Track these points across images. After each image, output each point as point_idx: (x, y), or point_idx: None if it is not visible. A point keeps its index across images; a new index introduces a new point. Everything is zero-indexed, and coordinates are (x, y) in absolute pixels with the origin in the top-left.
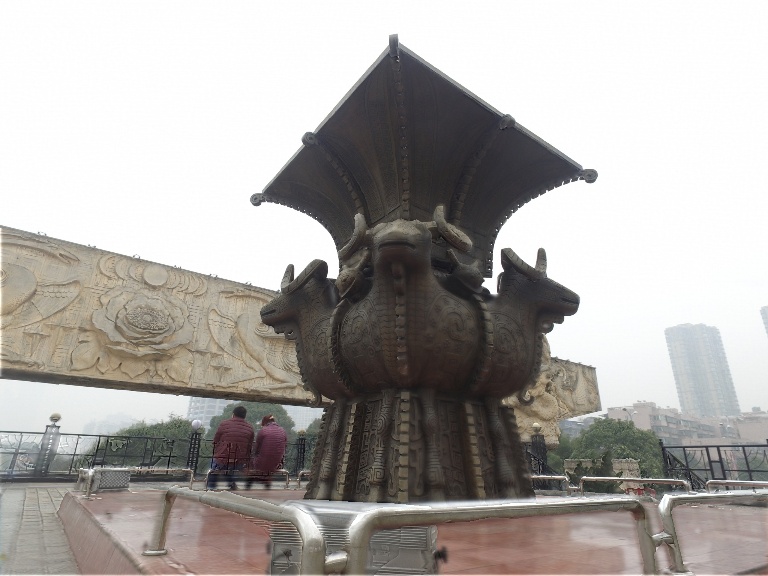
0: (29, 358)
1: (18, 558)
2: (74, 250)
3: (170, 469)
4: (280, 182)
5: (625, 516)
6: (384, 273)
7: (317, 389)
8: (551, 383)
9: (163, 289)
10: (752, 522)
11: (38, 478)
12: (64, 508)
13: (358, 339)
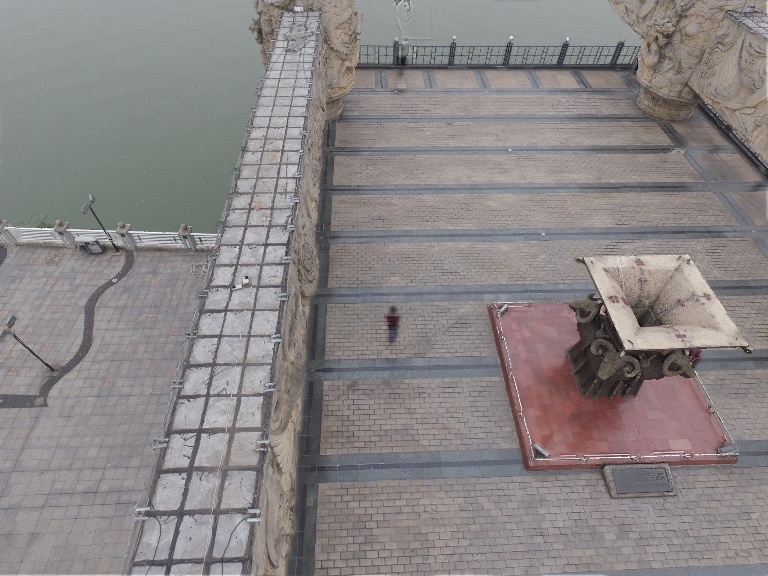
0: None
1: None
2: None
3: None
4: None
5: None
6: None
7: None
8: None
9: None
10: (537, 411)
11: None
12: None
13: None
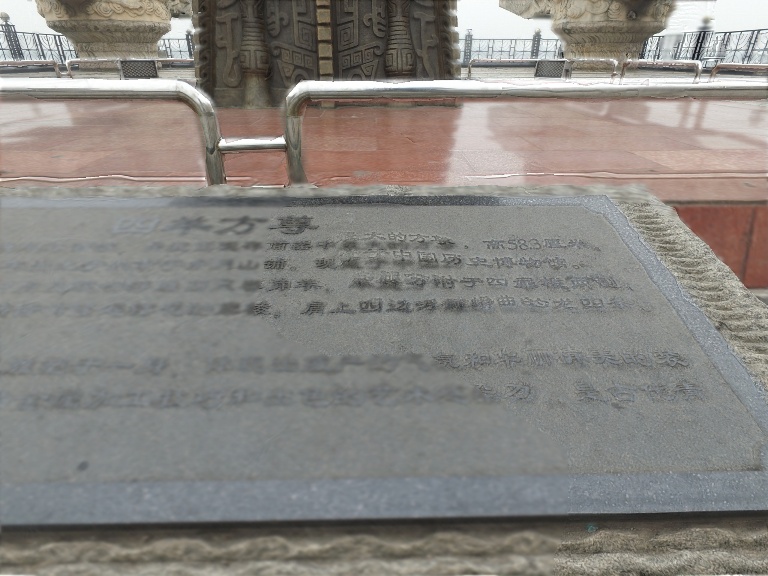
0: None
1: None
2: None
3: None
4: None
5: (65, 106)
6: None
7: None
8: None
9: None
10: None
11: None
12: None
13: None
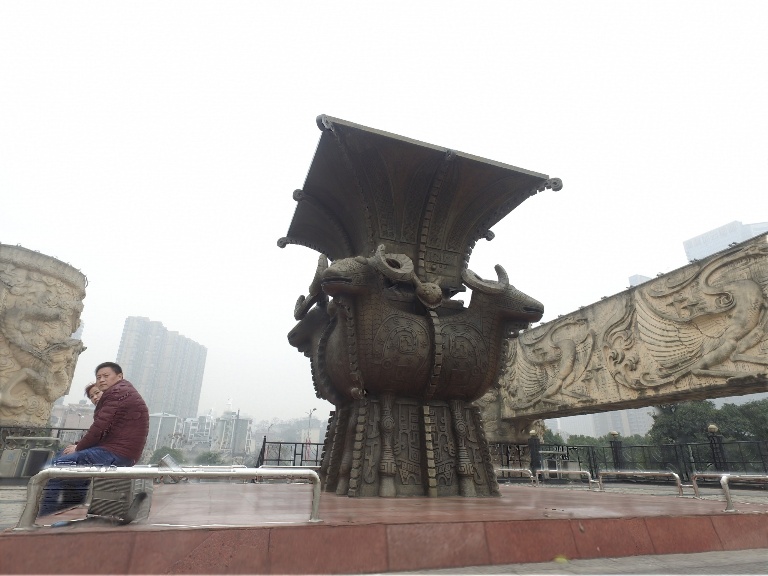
0: None
1: (609, 572)
2: None
3: (88, 468)
4: (366, 136)
5: None
6: (502, 318)
7: (368, 381)
8: (71, 360)
9: None
10: None
11: None
12: (180, 559)
13: (464, 356)
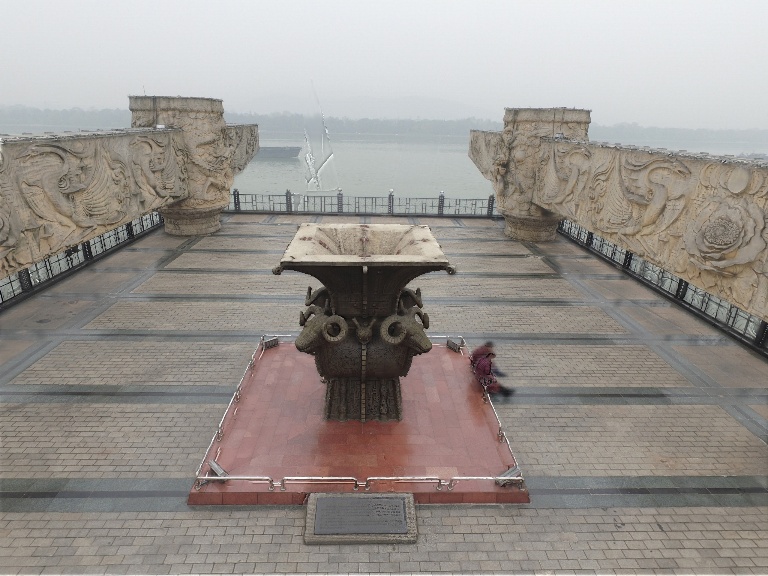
0: (658, 257)
1: None
2: (689, 164)
3: None
4: None
5: (285, 417)
6: None
7: None
8: None
9: (746, 195)
10: None
11: (752, 346)
12: None
13: None
